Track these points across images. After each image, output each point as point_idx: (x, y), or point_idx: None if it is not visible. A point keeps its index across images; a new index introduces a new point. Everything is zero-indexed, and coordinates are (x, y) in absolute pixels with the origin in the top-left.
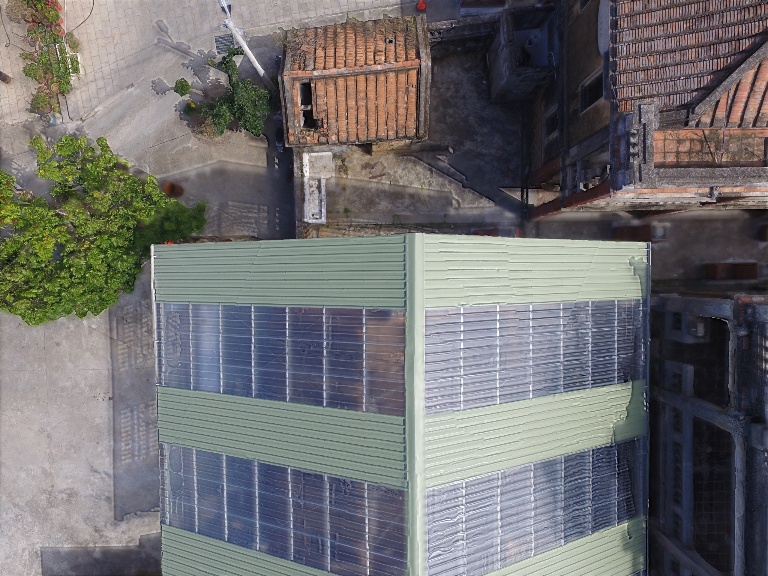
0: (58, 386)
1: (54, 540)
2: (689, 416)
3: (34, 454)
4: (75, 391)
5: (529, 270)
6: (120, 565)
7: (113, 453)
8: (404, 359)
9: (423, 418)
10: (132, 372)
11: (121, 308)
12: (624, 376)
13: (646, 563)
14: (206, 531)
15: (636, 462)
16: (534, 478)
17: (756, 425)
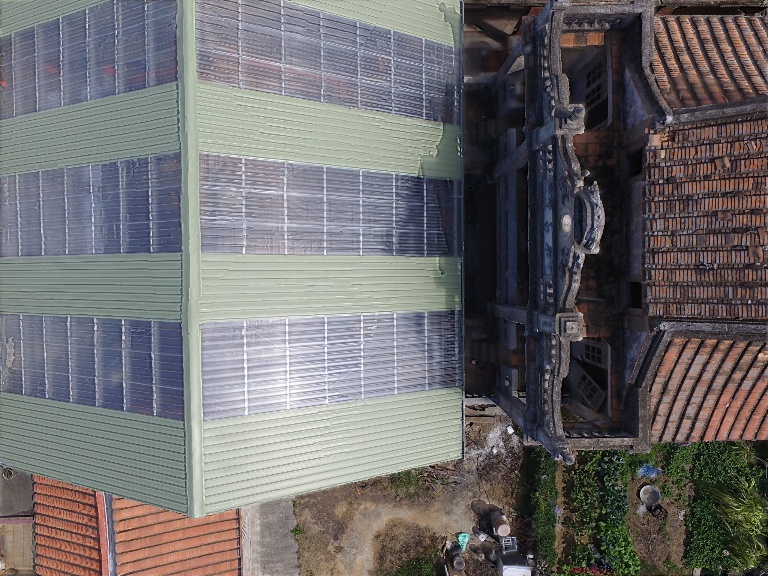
0: None
1: None
2: (512, 177)
3: None
4: None
5: None
6: None
7: None
8: (176, 25)
9: (194, 81)
10: None
11: None
12: (434, 115)
13: (462, 304)
14: (27, 251)
15: (449, 202)
16: (327, 180)
17: (534, 129)
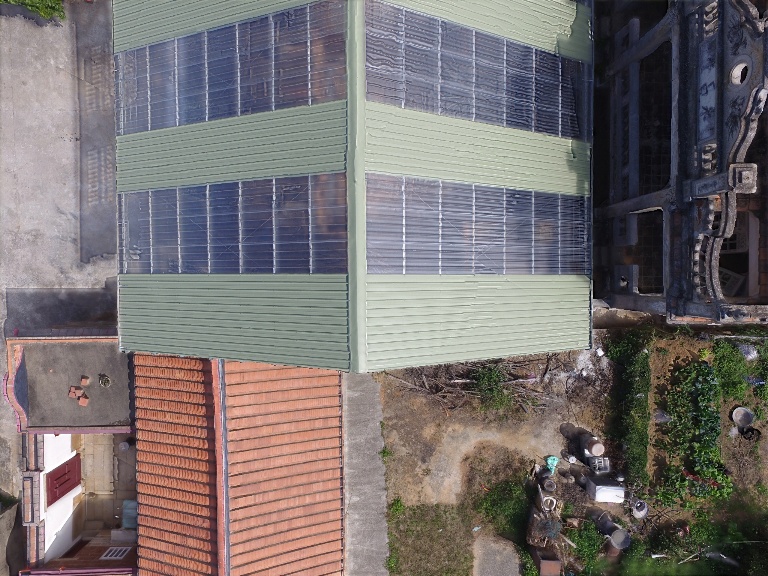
0: (25, 126)
1: (20, 281)
2: (635, 69)
3: (0, 194)
4: (42, 132)
5: None
6: (86, 307)
7: (80, 195)
8: None
9: None
10: (99, 113)
11: (89, 49)
12: None
13: (590, 191)
14: (158, 124)
15: (580, 85)
16: (476, 44)
17: None
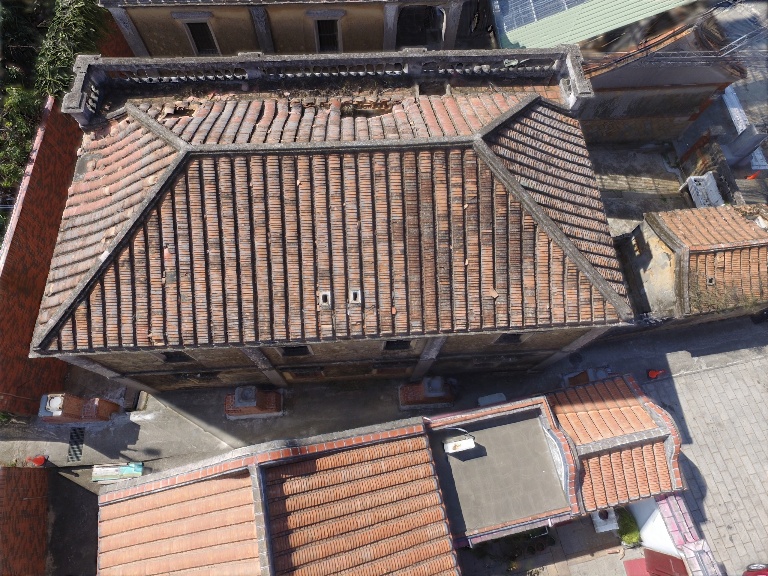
0: None
1: None
2: None
3: None
4: None
5: (641, 1)
6: None
7: None
8: None
9: None
10: None
11: None
12: None
13: None
14: None
15: None
16: None
17: None
